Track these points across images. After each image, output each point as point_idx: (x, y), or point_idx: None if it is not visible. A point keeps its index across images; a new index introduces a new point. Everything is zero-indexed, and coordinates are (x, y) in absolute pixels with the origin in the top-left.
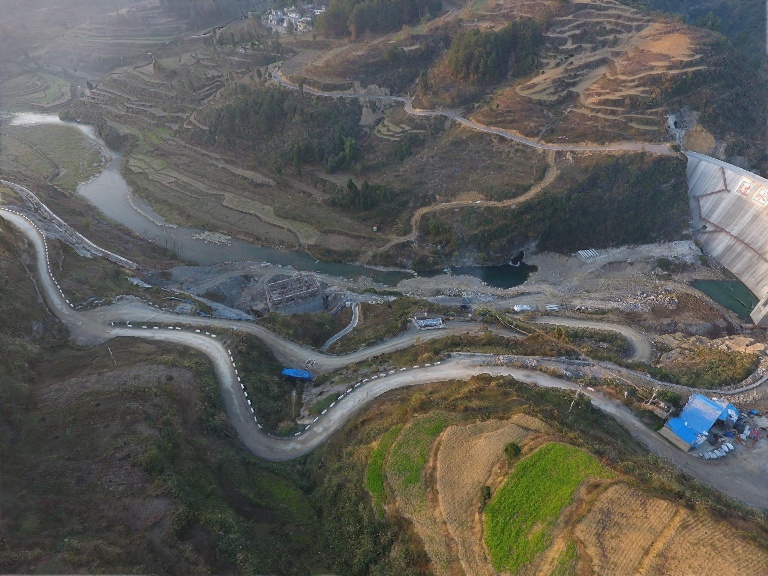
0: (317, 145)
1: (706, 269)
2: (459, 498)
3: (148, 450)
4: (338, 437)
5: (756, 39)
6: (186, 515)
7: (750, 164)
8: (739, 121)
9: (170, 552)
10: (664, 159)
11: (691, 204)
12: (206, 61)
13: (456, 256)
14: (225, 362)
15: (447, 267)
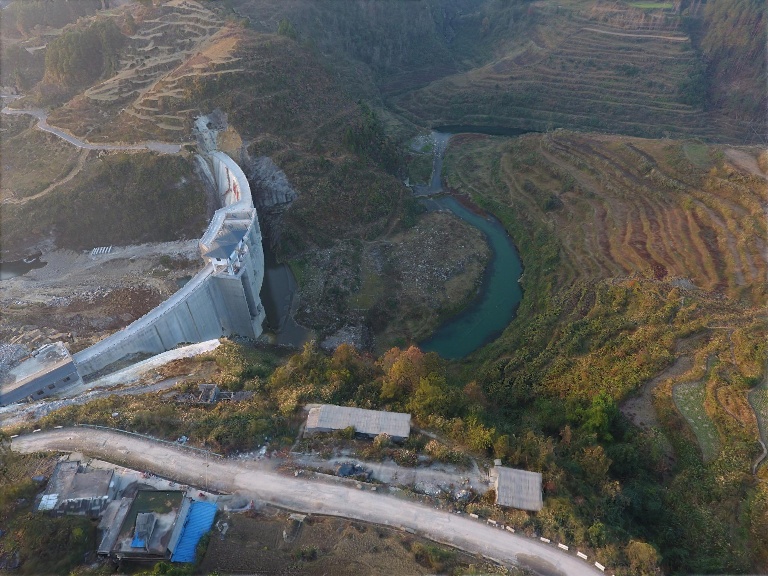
0: None
1: None
2: None
3: None
4: None
5: (495, 47)
6: None
7: (274, 165)
8: (277, 123)
9: None
10: (166, 158)
11: None
12: None
13: None
14: None
15: None
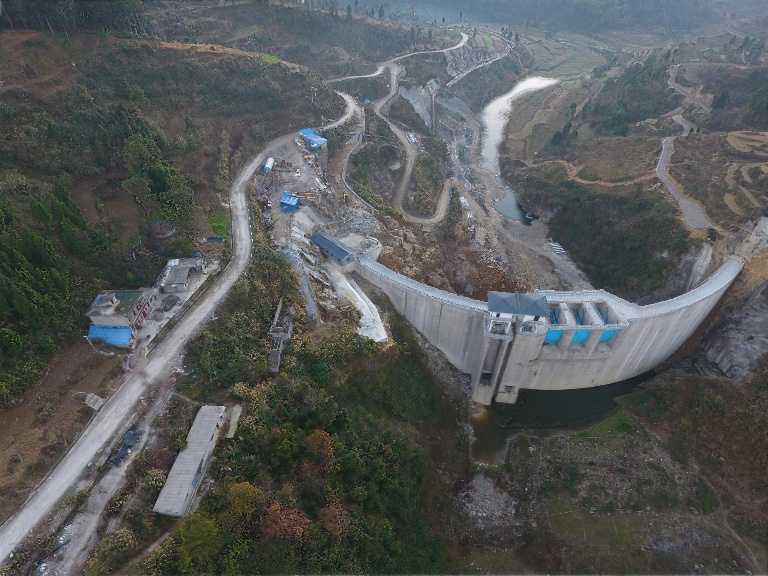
0: (611, 108)
1: None
2: None
3: None
4: None
5: None
6: None
7: None
8: None
9: None
10: (675, 223)
11: None
12: None
13: None
14: None
15: (510, 186)
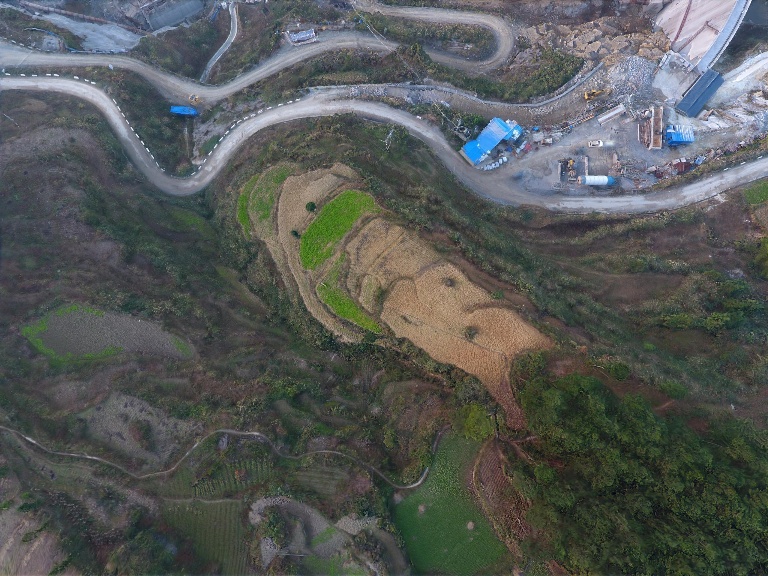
0: None
1: None
2: (290, 229)
3: (82, 211)
4: (223, 176)
5: None
6: (126, 250)
7: None
8: None
9: (125, 271)
10: None
11: None
12: None
13: None
14: (114, 112)
15: None
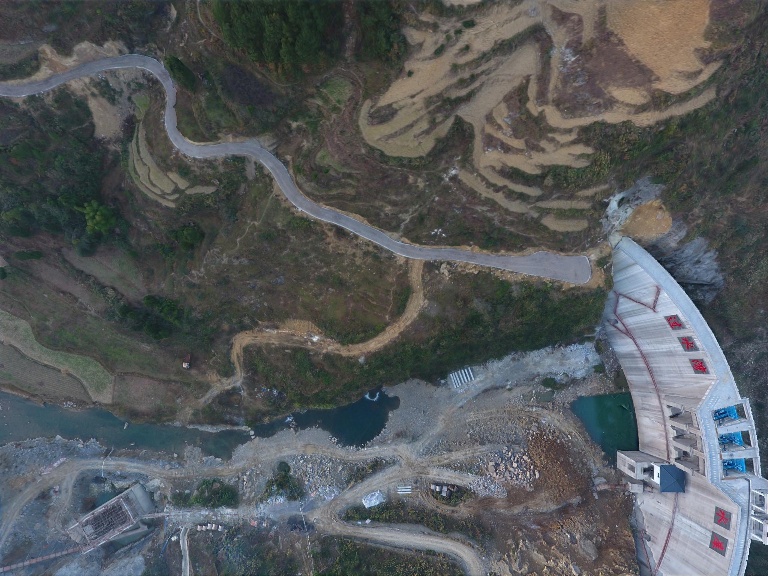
0: (40, 212)
1: (597, 378)
2: None
3: None
4: None
5: None
6: None
7: (709, 249)
8: (728, 174)
9: None
10: (577, 295)
11: (609, 294)
12: None
13: (297, 407)
14: None
15: (289, 415)
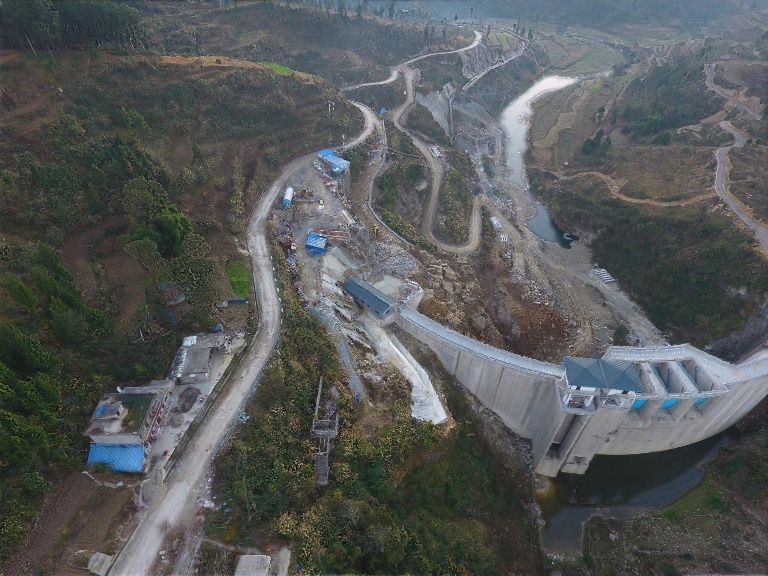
0: (644, 112)
1: None
2: None
3: None
4: None
5: None
6: None
7: None
8: None
9: None
10: (754, 256)
11: None
12: (737, 48)
13: None
14: None
15: (542, 202)
